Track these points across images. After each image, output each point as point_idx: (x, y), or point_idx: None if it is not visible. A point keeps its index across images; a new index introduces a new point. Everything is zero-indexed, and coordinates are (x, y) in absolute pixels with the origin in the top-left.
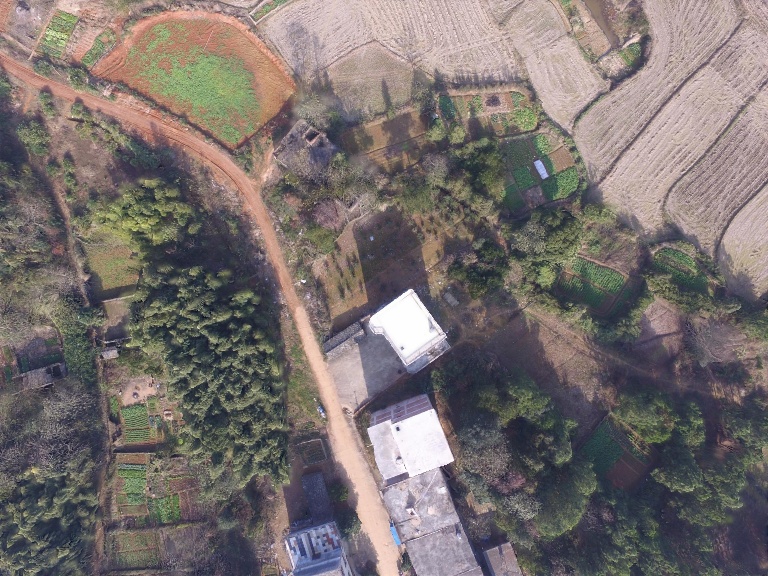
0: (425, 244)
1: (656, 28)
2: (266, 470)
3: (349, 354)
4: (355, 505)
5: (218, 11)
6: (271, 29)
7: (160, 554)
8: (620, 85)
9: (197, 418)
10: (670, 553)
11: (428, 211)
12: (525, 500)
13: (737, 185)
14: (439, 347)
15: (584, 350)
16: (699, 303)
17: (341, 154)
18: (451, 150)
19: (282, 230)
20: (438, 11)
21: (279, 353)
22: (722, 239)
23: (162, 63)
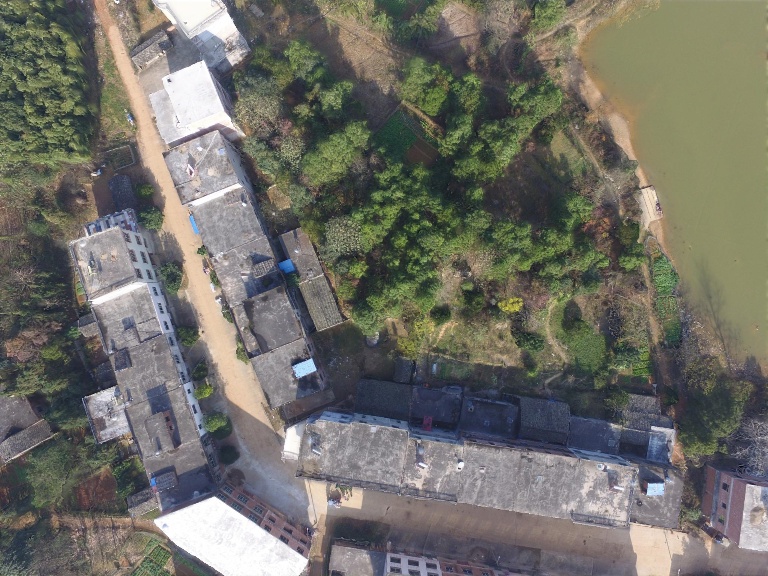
0: None
1: None
2: (59, 149)
3: (158, 65)
4: (162, 207)
5: None
6: None
7: None
8: None
9: None
10: None
11: None
12: None
13: None
14: (236, 44)
15: (382, 50)
16: (493, 1)
17: None
18: None
19: None
20: None
21: (93, 69)
22: None
23: None
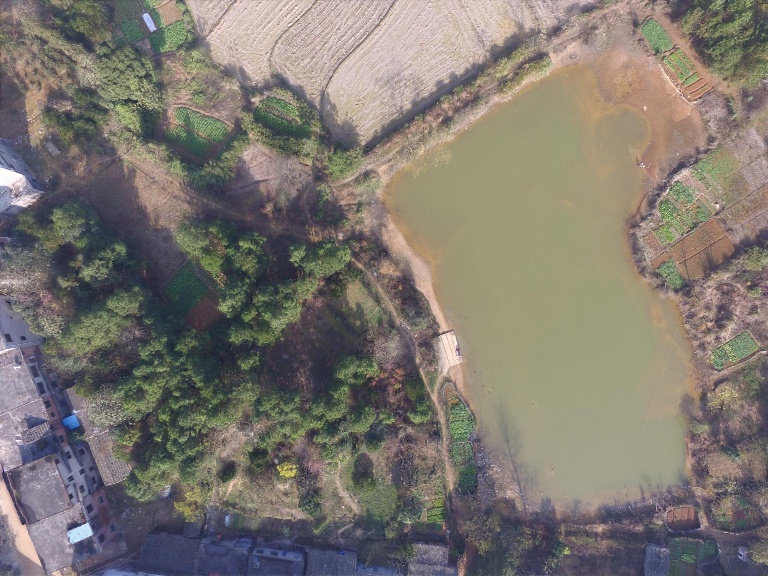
0: (29, 95)
1: None
2: None
3: None
4: None
5: None
6: None
7: None
8: None
9: None
10: (202, 369)
11: (30, 62)
12: None
13: (342, 36)
14: (23, 190)
15: (179, 195)
16: (292, 147)
17: None
18: None
19: None
20: None
21: None
22: (326, 89)
23: None
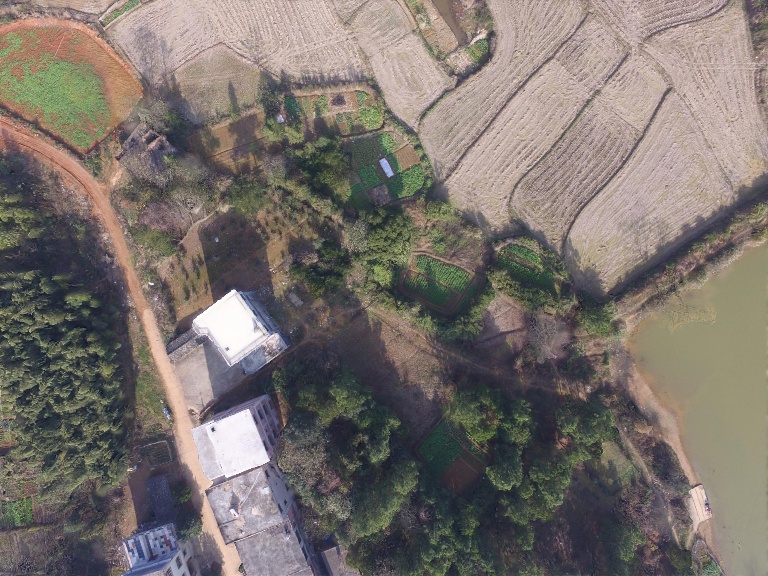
0: (270, 244)
1: (501, 24)
2: (97, 472)
3: (195, 355)
4: (201, 506)
5: (68, 18)
6: (120, 34)
7: (15, 557)
8: (465, 82)
9: (28, 421)
10: (489, 552)
11: (272, 212)
12: (337, 500)
13: (583, 180)
14: (277, 347)
15: (426, 348)
16: (541, 299)
17: (169, 156)
18: (289, 150)
19: (130, 233)
20: (284, 12)
21: (127, 355)
22: (568, 234)
23: (14, 70)
